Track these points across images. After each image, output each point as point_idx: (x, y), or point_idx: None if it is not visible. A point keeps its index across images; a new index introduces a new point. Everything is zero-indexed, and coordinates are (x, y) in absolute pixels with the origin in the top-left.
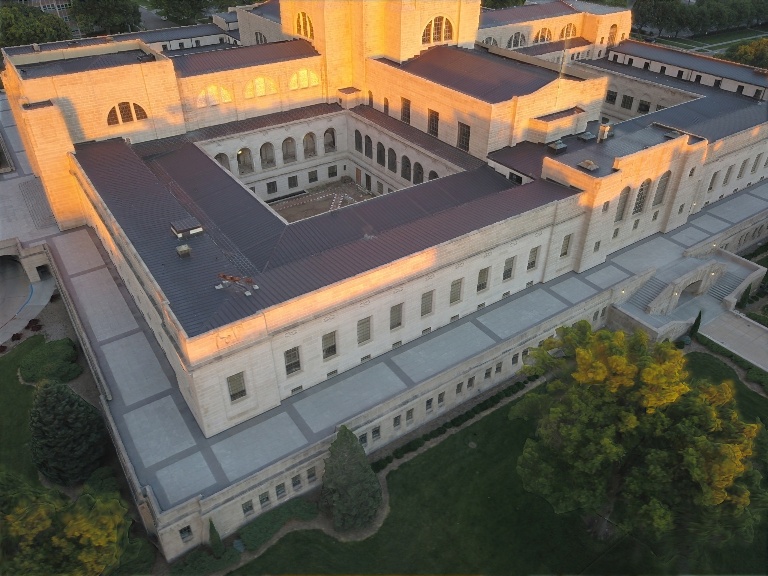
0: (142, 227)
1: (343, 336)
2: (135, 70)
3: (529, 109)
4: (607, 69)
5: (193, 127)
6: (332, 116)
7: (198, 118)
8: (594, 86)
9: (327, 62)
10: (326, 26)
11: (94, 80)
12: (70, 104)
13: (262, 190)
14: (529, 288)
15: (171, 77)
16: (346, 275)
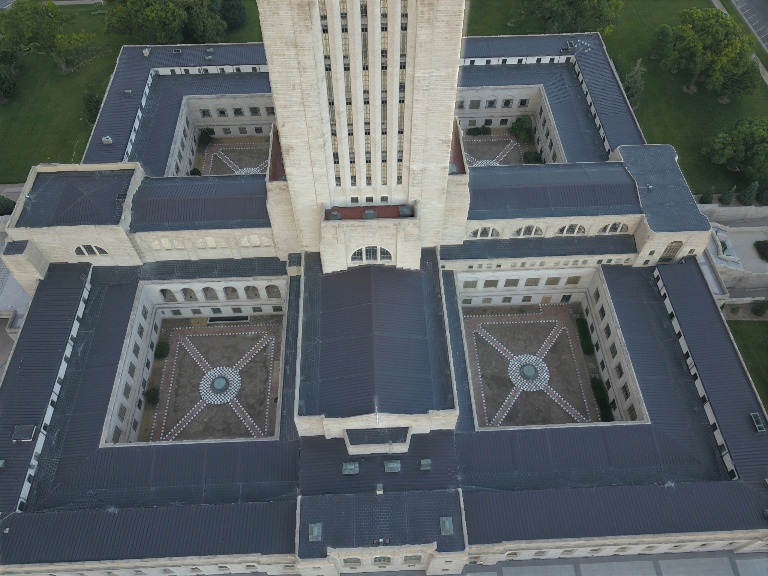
0: (7, 414)
1: (61, 575)
2: (91, 229)
3: (341, 425)
4: (614, 304)
5: (150, 260)
6: (271, 279)
7: (155, 255)
8: (439, 415)
9: (275, 236)
10: (271, 215)
11: (59, 232)
12: (44, 243)
13: (207, 311)
14: (254, 573)
15: (123, 235)
16: (55, 555)
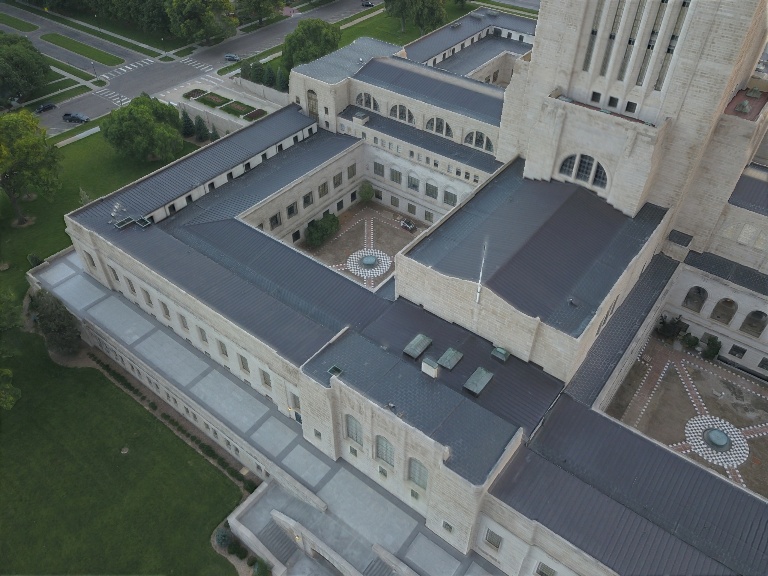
0: None
1: None
2: None
3: None
4: None
5: None
6: None
7: None
8: None
9: None
10: None
11: None
12: None
13: None
14: None
15: None
16: None
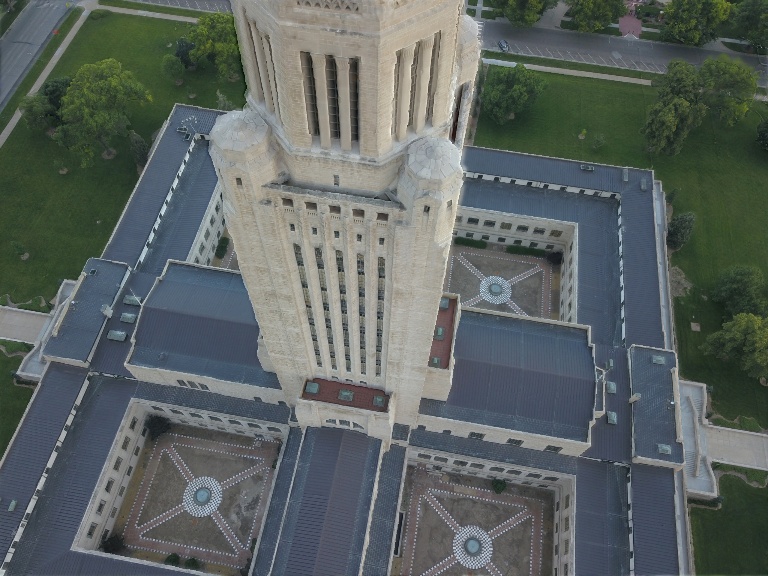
0: None
1: None
2: None
3: None
4: (482, 208)
5: None
6: None
7: None
8: None
9: None
10: None
11: None
12: None
13: None
14: None
15: None
16: None
